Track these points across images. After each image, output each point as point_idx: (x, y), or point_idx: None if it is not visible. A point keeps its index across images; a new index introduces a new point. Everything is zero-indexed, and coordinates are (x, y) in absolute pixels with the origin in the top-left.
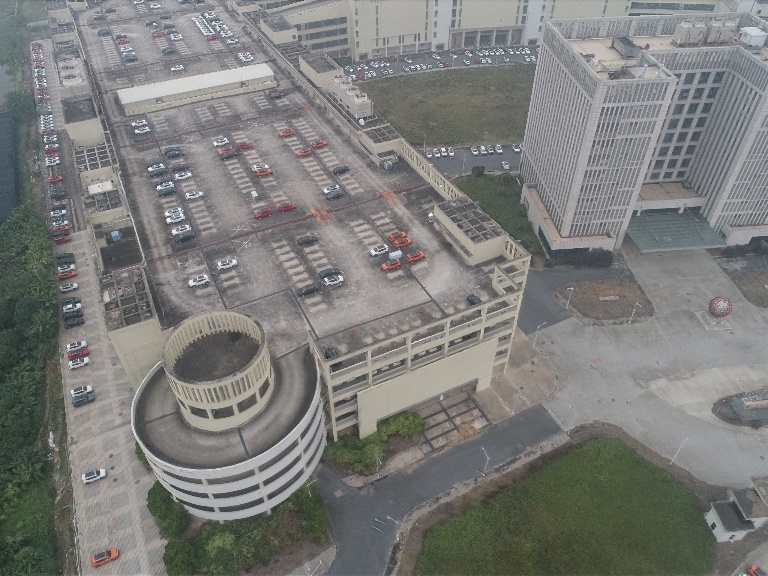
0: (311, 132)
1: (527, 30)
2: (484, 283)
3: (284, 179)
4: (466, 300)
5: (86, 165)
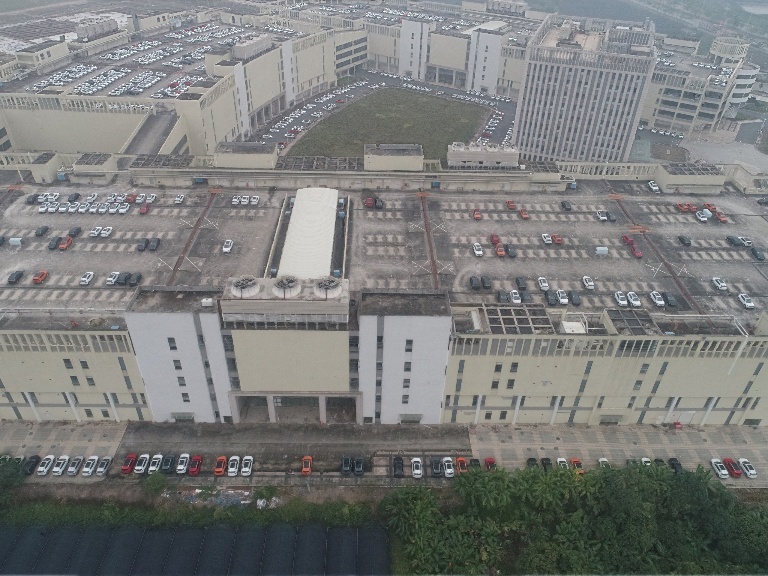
0: (478, 204)
1: (286, 94)
2: (741, 195)
3: (569, 233)
4: (761, 205)
5: (535, 327)
